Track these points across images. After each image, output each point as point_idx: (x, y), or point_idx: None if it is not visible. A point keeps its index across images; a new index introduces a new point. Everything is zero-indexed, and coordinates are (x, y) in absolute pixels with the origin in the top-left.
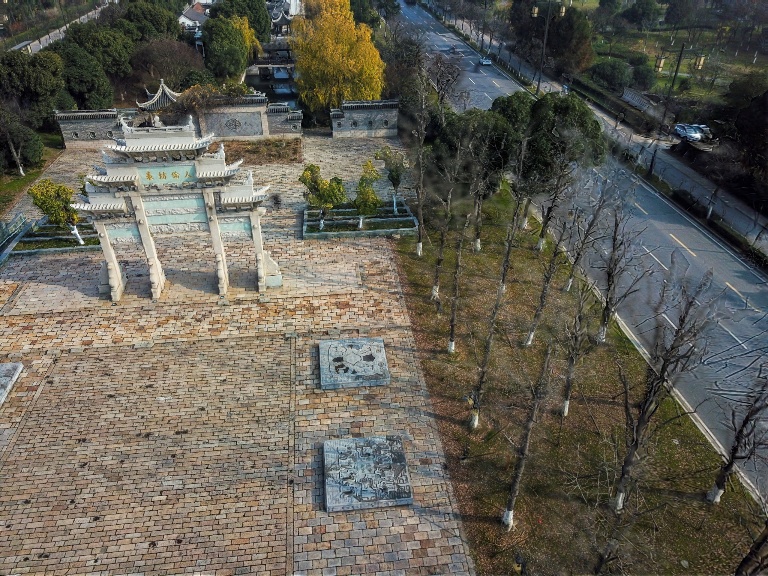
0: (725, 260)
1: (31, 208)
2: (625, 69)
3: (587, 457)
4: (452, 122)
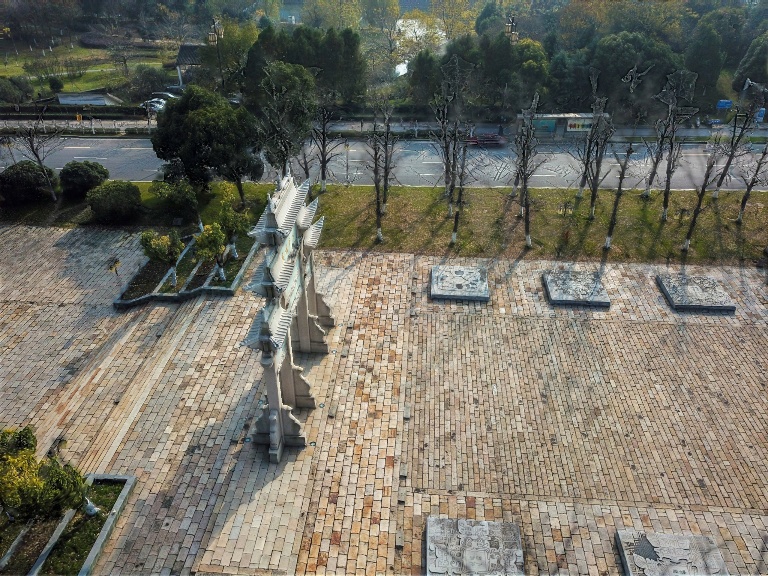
0: (365, 145)
1: None
2: (7, 83)
3: (556, 218)
4: (201, 127)
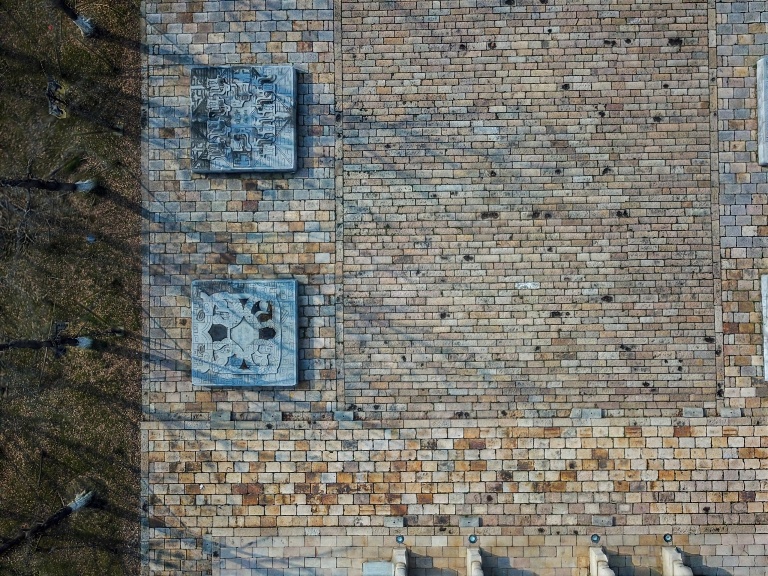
0: None
1: None
2: None
3: None
4: None
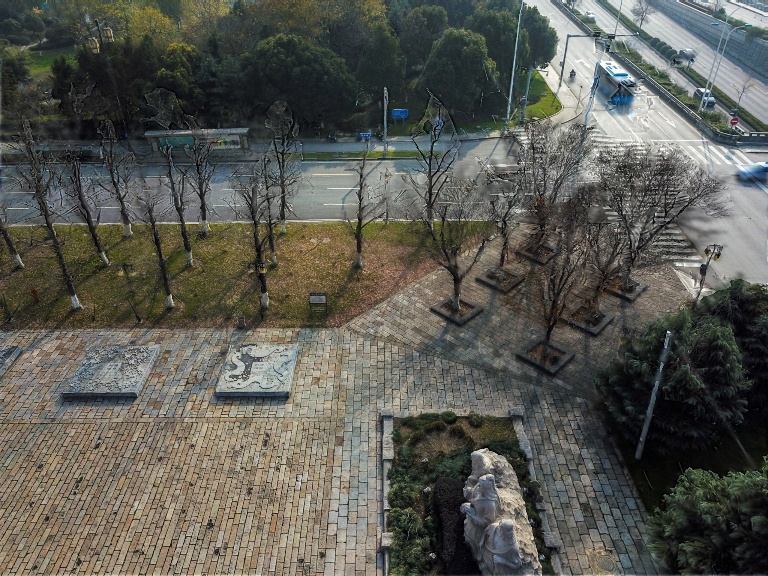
0: None
1: None
2: None
3: None
4: None
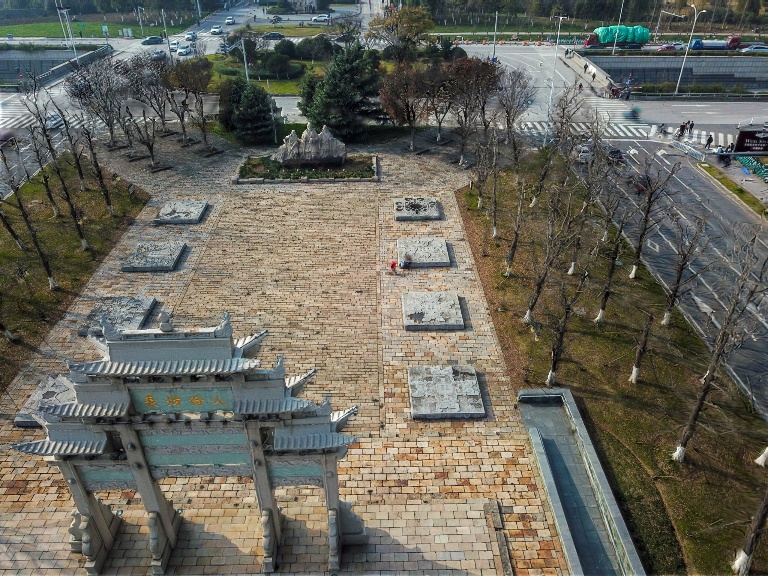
0: None
1: None
2: None
3: None
4: None
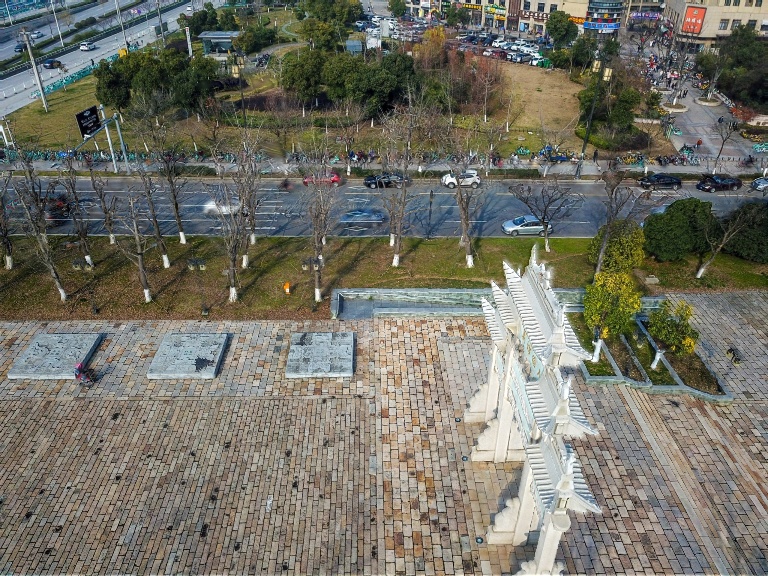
0: None
1: (703, 306)
2: None
3: None
4: None
